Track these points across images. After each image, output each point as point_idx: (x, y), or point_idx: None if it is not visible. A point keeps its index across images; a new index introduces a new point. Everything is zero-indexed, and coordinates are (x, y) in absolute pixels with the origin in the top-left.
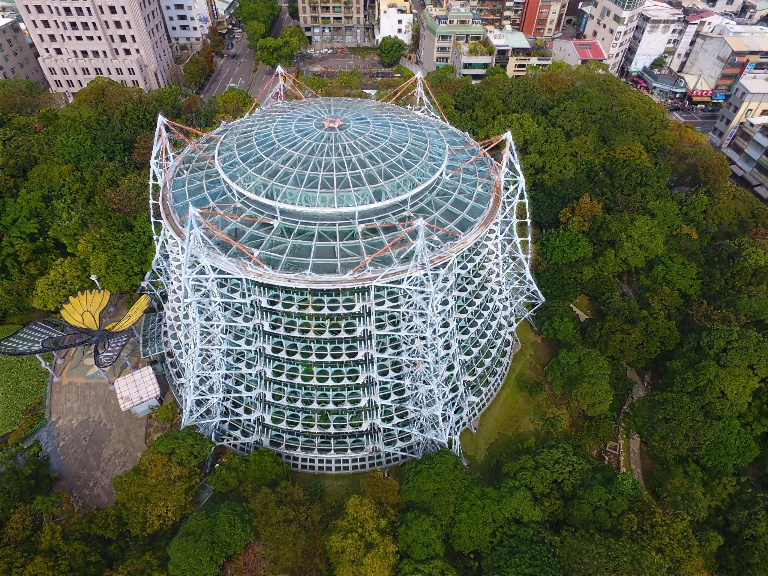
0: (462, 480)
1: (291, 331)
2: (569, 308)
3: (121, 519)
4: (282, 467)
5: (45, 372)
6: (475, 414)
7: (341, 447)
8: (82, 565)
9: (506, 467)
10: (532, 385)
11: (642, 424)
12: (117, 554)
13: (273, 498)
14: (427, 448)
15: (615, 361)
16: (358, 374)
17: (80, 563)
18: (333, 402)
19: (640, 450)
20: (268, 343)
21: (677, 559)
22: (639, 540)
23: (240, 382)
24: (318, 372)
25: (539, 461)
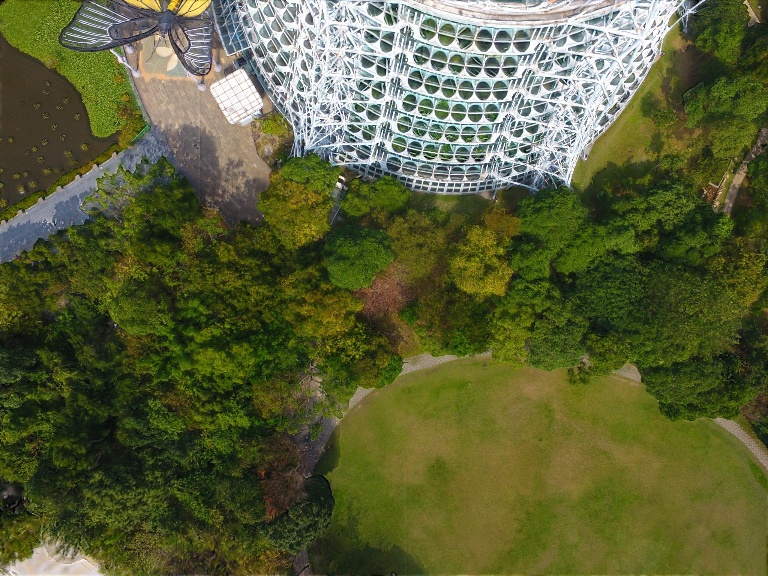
0: (577, 219)
1: (440, 68)
2: (744, 8)
3: (275, 237)
4: (405, 194)
5: (116, 62)
6: (590, 141)
7: (457, 174)
8: (259, 274)
9: (617, 205)
10: (663, 114)
11: (764, 169)
12: (280, 263)
13: (405, 226)
14: (536, 174)
15: (766, 88)
16: (497, 112)
17: (258, 273)
18: (462, 137)
19: (741, 185)
20: (404, 74)
21: (743, 293)
22: (719, 278)
23: (361, 107)
24: (453, 107)
25: (650, 202)
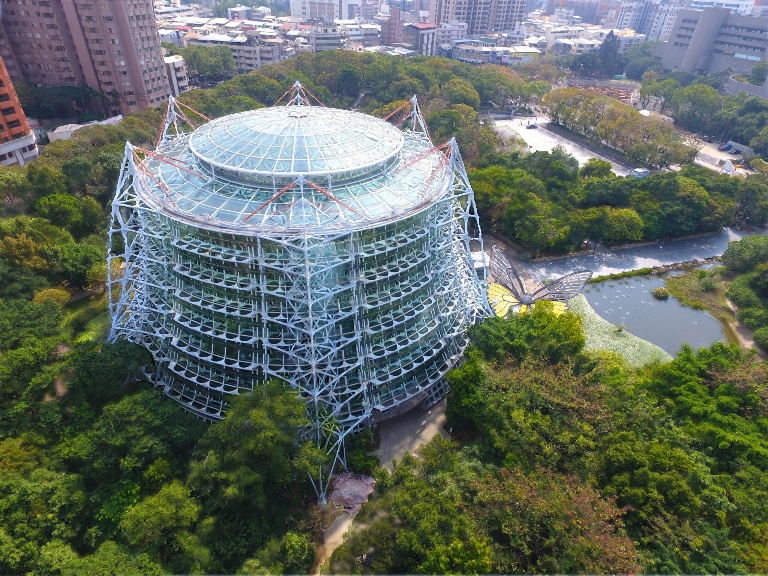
0: None
1: None
2: None
3: None
4: None
5: None
6: None
7: None
8: None
9: None
10: None
11: None
12: None
13: None
14: None
15: None
16: None
17: None
18: None
19: None
20: None
21: None
22: None
23: None
24: None
25: None
